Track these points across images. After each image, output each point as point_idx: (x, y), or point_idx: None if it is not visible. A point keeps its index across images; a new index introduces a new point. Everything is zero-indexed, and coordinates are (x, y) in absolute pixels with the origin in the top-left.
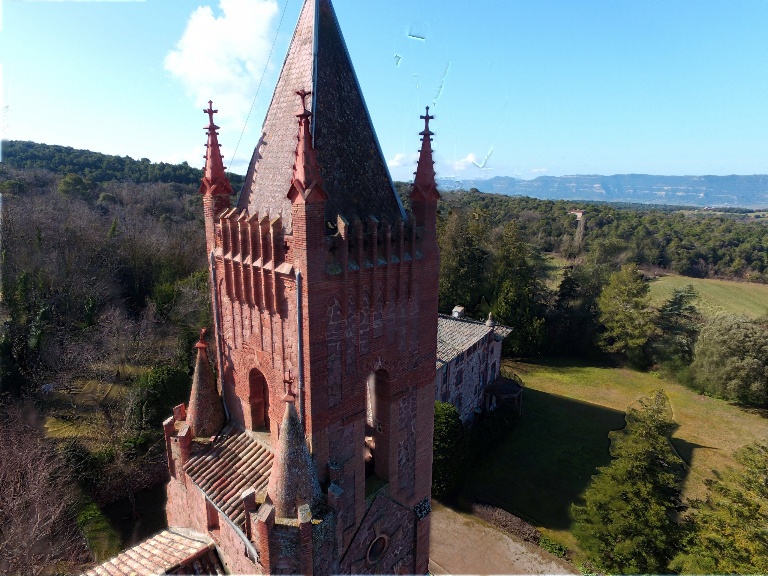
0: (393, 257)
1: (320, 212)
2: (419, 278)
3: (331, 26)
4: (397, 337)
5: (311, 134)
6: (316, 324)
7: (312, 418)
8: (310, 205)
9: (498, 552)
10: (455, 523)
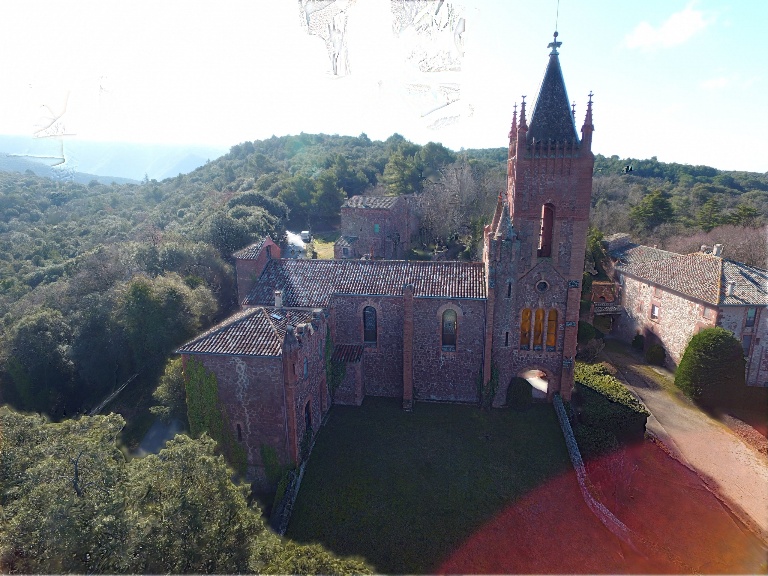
0: (560, 155)
1: (524, 136)
2: (578, 167)
3: (555, 66)
4: (562, 192)
5: (534, 109)
6: (519, 176)
7: (514, 211)
8: (520, 133)
9: (722, 443)
10: (700, 419)
